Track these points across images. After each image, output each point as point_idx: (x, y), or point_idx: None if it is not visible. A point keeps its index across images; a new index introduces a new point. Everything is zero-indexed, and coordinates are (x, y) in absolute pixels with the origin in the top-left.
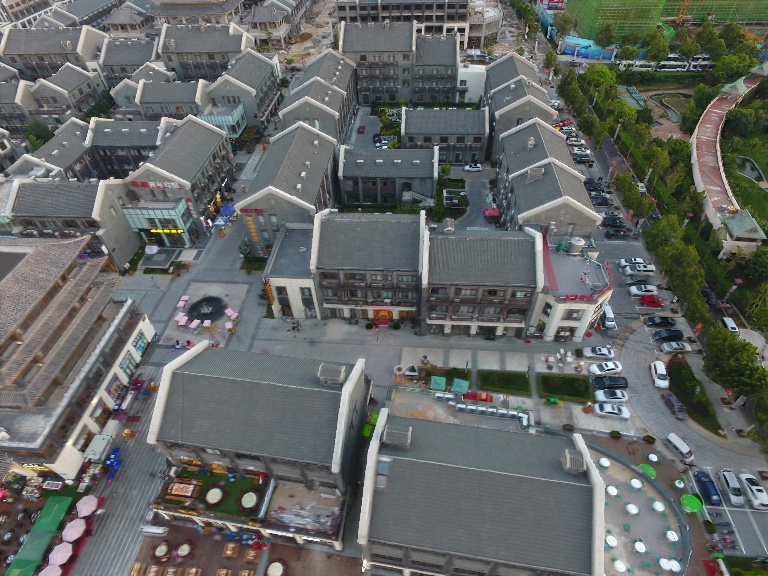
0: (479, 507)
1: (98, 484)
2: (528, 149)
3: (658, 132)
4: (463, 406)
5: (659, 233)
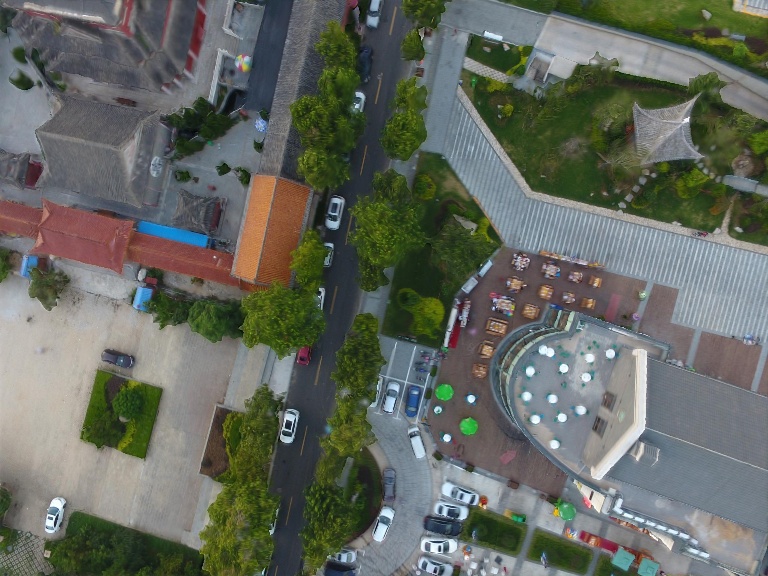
0: (744, 429)
1: None
2: None
3: None
4: (683, 535)
5: None
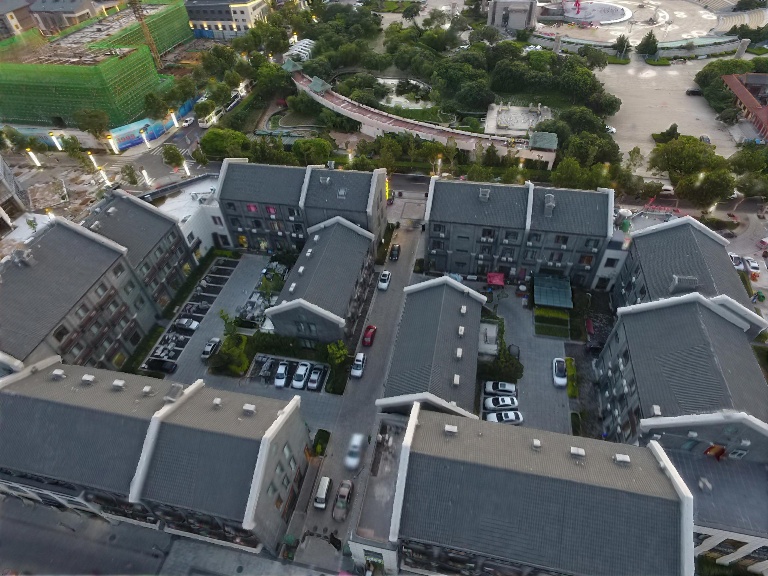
0: None
1: None
2: (486, 200)
3: (343, 144)
4: None
5: (579, 174)
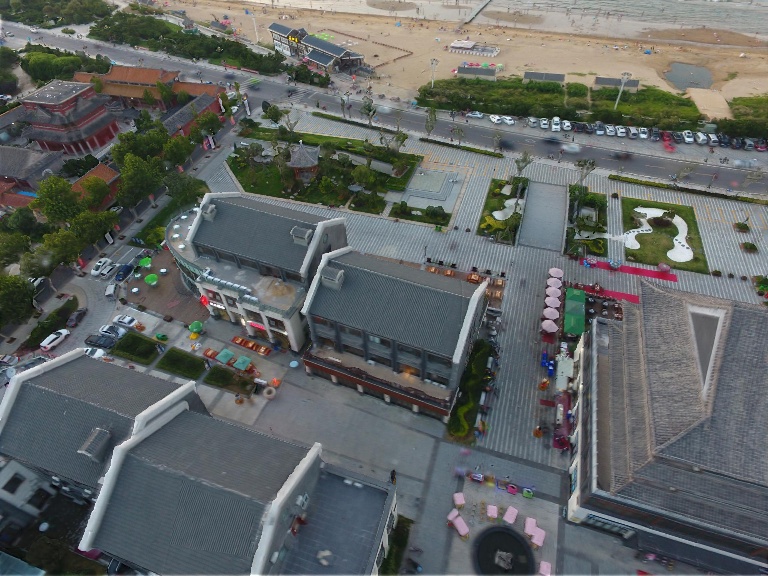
0: None
1: (554, 352)
2: None
3: None
4: (242, 287)
5: None
